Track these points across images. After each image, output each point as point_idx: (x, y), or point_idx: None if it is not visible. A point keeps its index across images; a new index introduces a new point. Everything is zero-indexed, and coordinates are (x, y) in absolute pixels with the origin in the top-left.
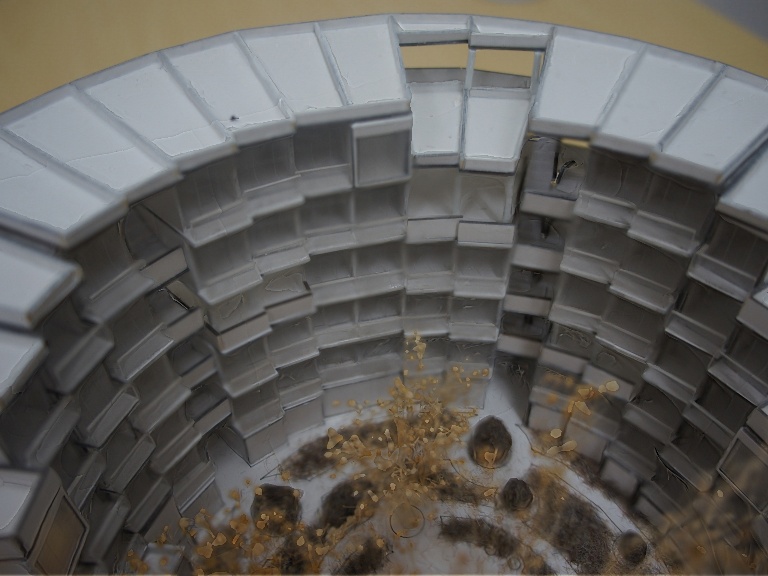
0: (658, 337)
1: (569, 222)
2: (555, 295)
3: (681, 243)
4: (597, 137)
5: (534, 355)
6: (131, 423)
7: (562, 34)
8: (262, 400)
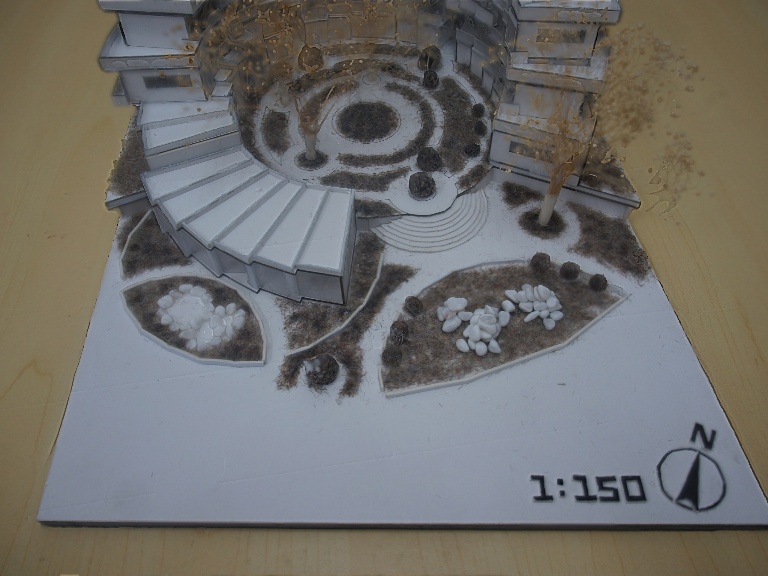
0: None
1: None
2: None
3: None
4: None
5: None
6: None
7: None
8: (317, 3)
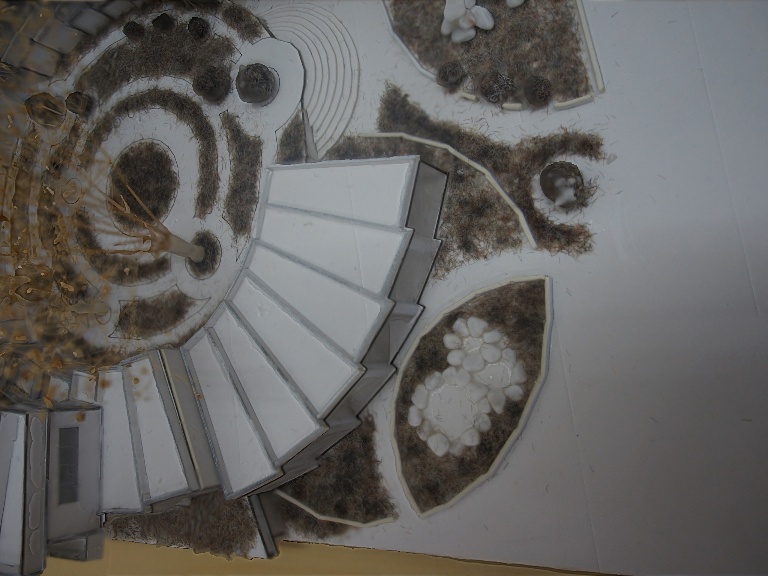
0: None
1: None
2: None
3: None
4: None
5: None
6: None
7: None
8: None
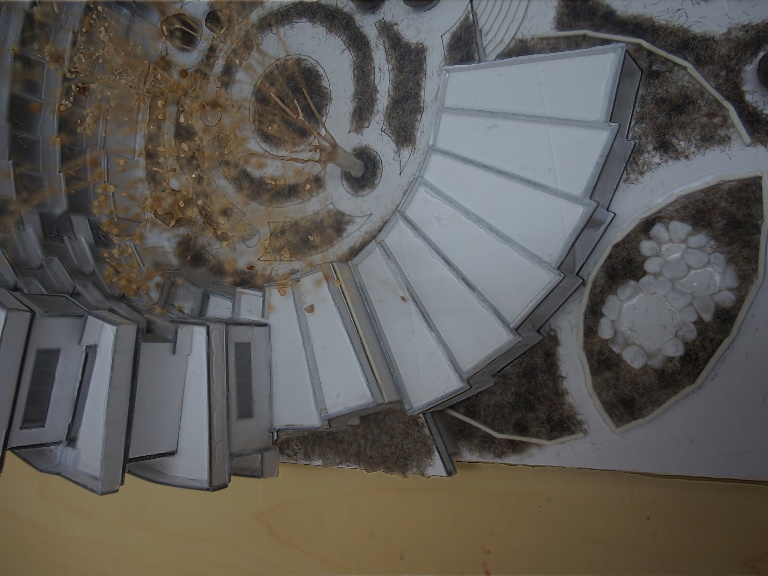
0: None
1: None
2: None
3: None
4: None
5: None
6: (32, 268)
7: None
8: (86, 194)
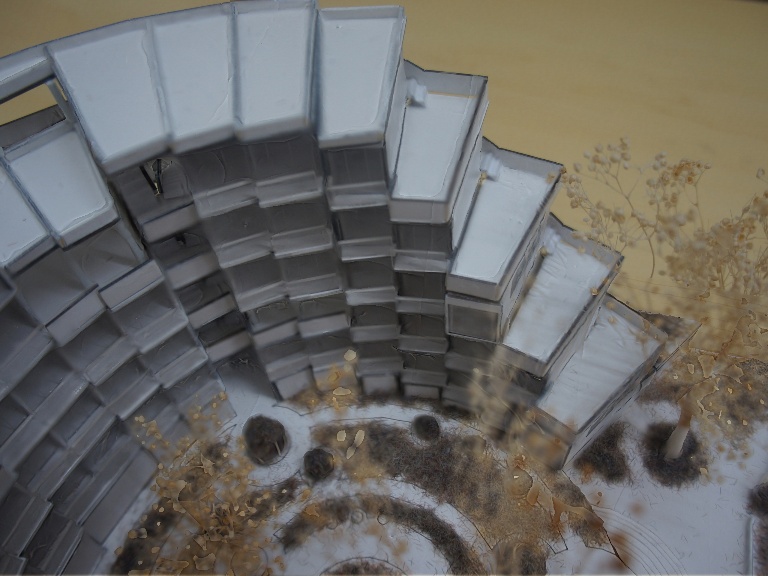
0: (338, 265)
1: (200, 224)
2: (231, 288)
3: (309, 187)
4: (176, 144)
5: (247, 343)
6: None
7: (59, 49)
8: None
